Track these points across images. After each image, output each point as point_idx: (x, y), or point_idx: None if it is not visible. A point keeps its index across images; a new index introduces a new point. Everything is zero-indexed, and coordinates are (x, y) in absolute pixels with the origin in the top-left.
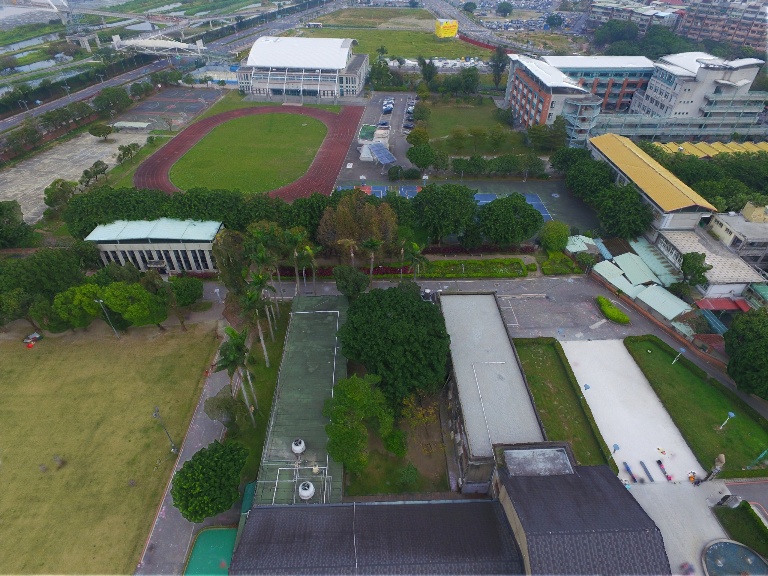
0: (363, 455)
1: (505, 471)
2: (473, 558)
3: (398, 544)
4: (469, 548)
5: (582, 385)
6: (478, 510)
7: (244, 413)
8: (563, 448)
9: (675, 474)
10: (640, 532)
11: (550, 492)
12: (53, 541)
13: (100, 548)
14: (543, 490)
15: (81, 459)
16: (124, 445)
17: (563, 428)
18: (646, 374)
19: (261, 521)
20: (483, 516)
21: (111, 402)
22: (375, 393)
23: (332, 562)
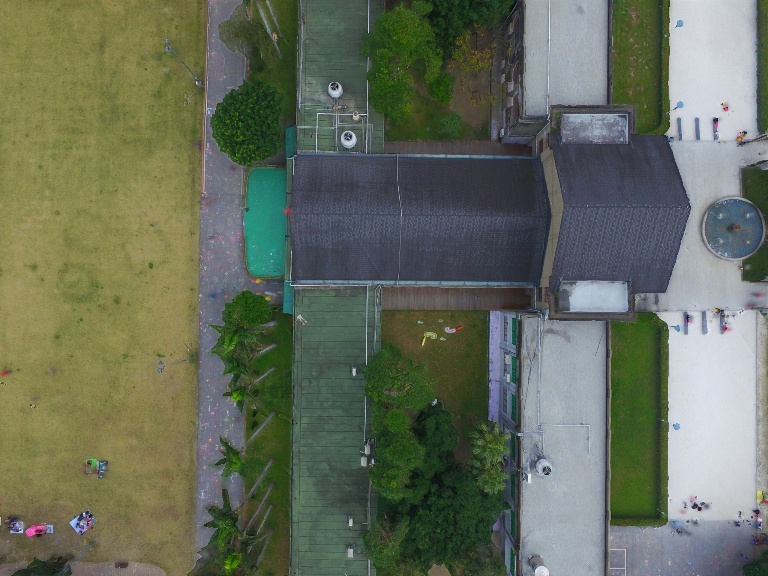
0: (407, 106)
1: (557, 137)
2: (506, 213)
3: (439, 197)
4: (504, 204)
5: (673, 16)
6: (518, 167)
7: (269, 47)
8: (627, 114)
9: (725, 133)
10: (672, 208)
11: (598, 163)
12: (116, 171)
13: (162, 179)
14: (592, 161)
15: (102, 89)
16: (142, 74)
17: (629, 74)
18: (760, 3)
19: (309, 169)
20: (521, 174)
21: (103, 16)
22: (423, 28)
23: (380, 211)
